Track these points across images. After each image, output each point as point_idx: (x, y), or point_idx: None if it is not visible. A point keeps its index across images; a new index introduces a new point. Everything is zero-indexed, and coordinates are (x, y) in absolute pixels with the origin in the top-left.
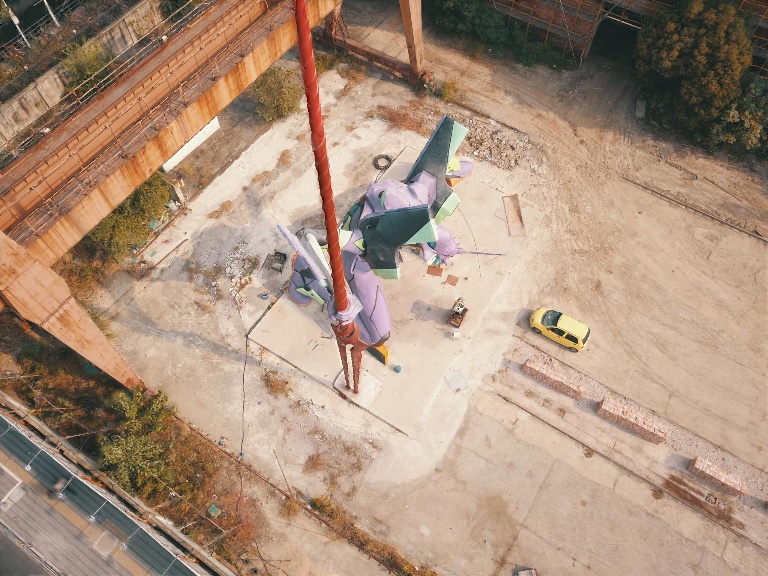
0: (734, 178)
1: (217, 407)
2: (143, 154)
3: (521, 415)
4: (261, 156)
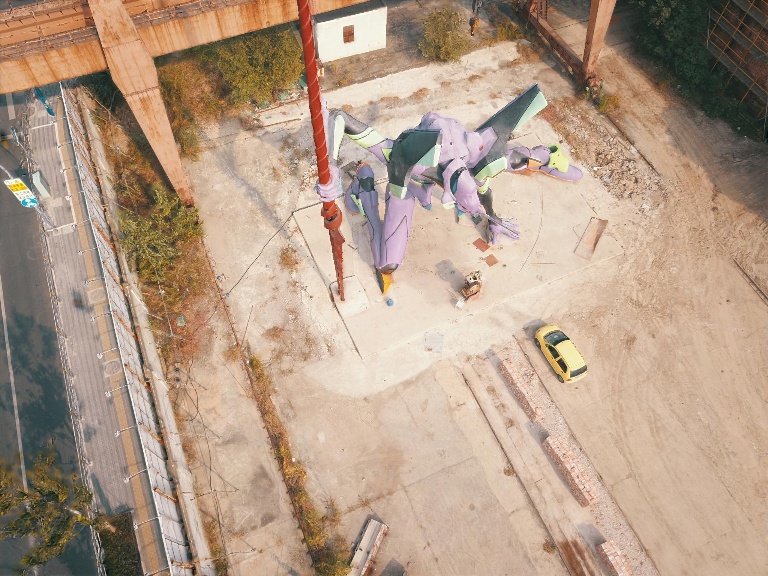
0: None
1: (235, 251)
2: (266, 4)
3: (470, 402)
4: (402, 84)
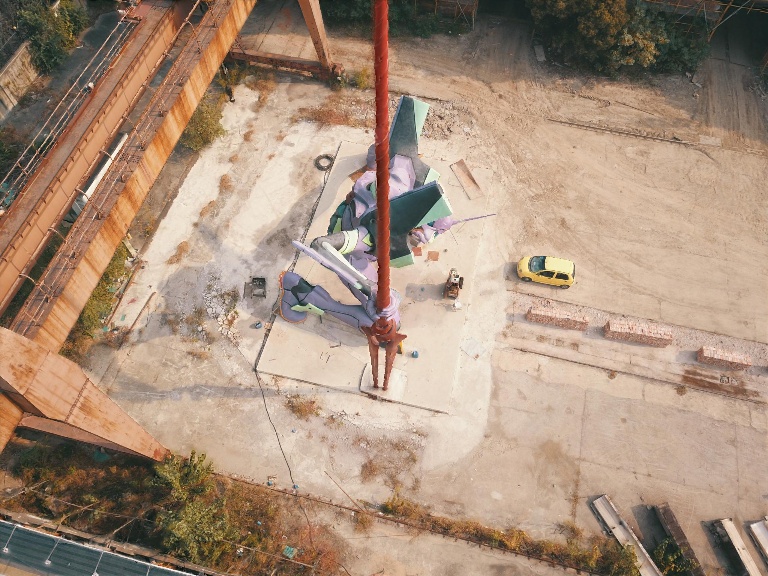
0: (640, 96)
1: (252, 449)
2: (116, 210)
3: (541, 360)
4: (200, 188)
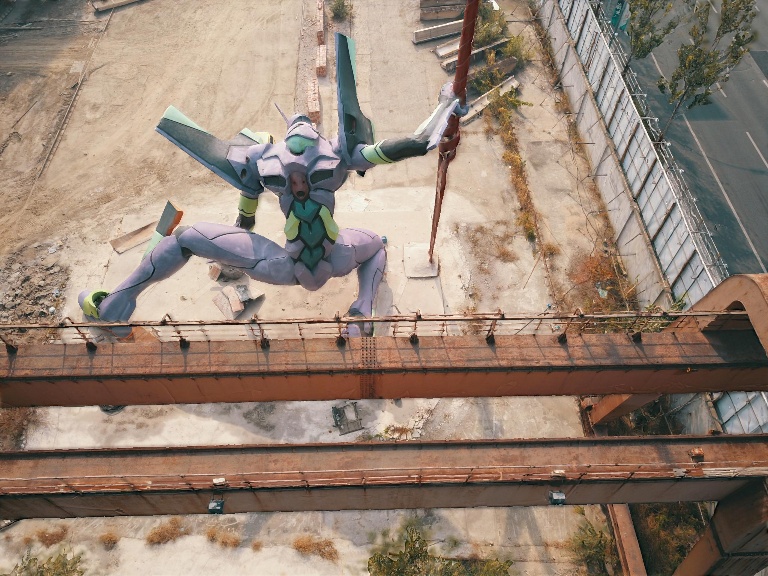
0: (5, 111)
1: None
2: None
3: None
4: (180, 574)
